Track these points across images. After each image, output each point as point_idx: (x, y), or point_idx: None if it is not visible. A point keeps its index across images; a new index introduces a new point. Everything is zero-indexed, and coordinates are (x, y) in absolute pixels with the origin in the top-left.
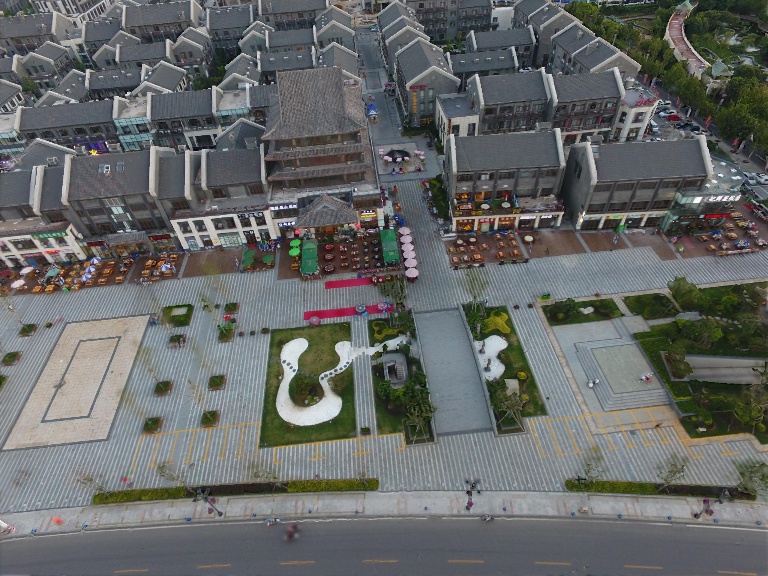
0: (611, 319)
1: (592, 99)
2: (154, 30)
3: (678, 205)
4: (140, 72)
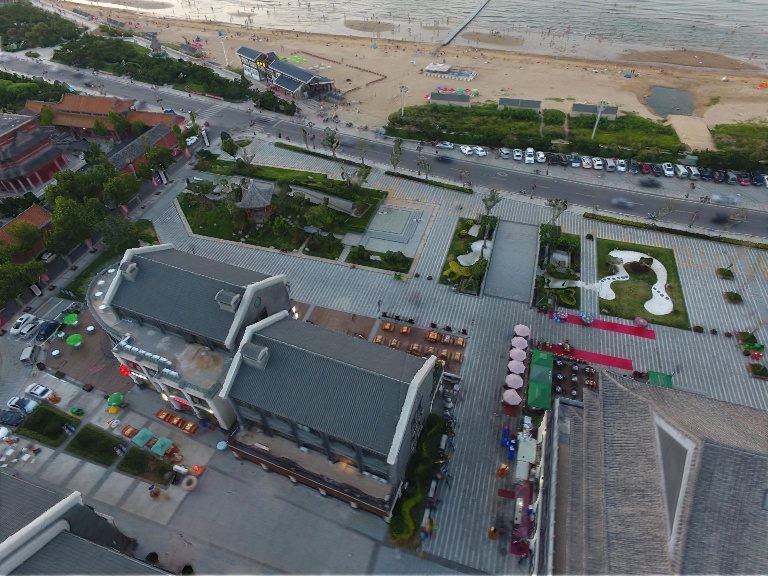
0: None
1: (7, 474)
2: None
3: None
4: None
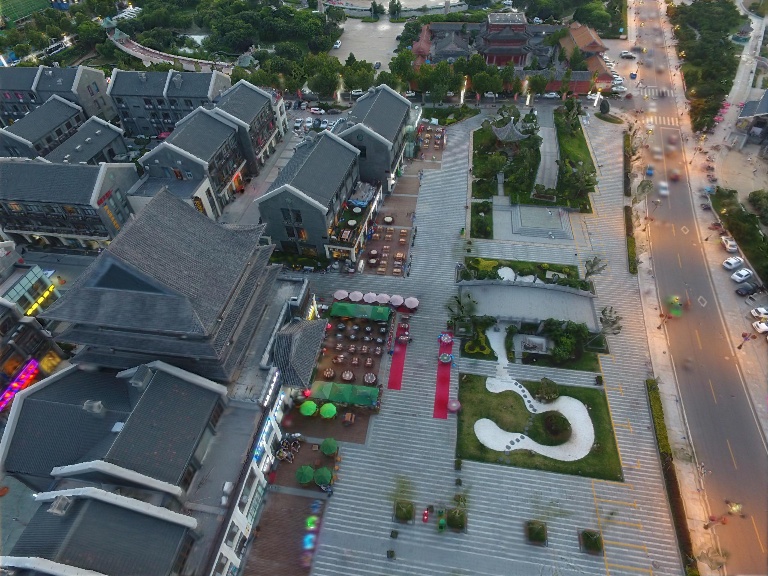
0: (493, 209)
1: (260, 111)
2: None
3: (406, 135)
4: None
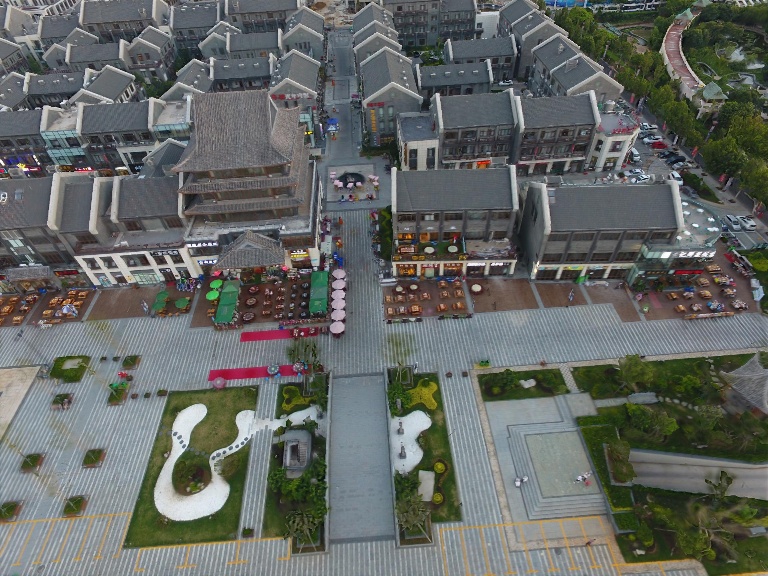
0: (554, 396)
1: (563, 126)
2: (114, 28)
3: (645, 258)
4: (83, 77)
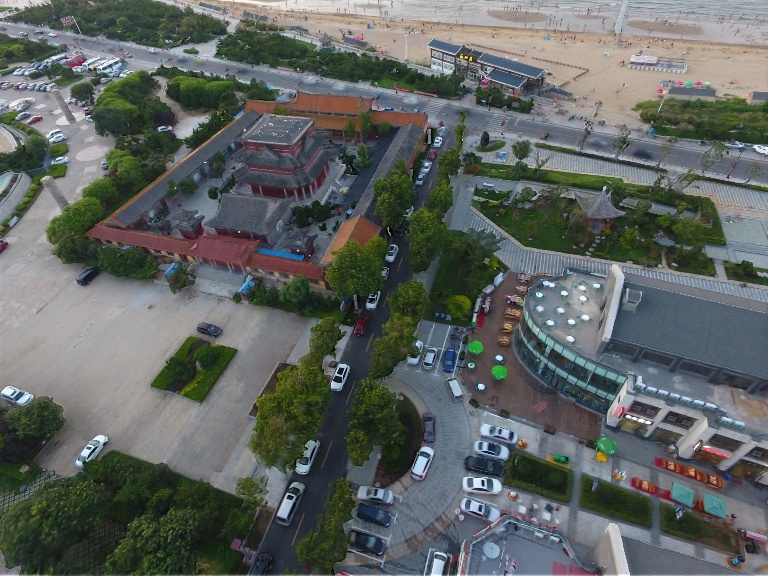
0: None
1: (706, 561)
2: None
3: None
4: None
